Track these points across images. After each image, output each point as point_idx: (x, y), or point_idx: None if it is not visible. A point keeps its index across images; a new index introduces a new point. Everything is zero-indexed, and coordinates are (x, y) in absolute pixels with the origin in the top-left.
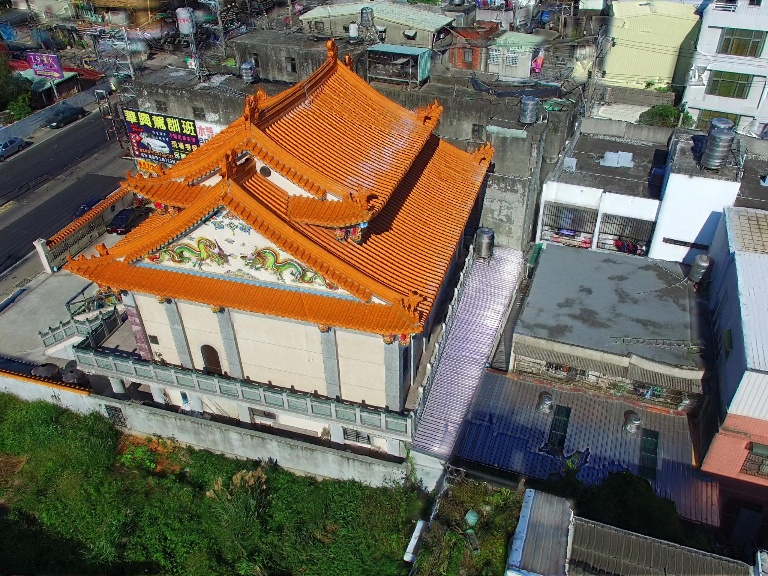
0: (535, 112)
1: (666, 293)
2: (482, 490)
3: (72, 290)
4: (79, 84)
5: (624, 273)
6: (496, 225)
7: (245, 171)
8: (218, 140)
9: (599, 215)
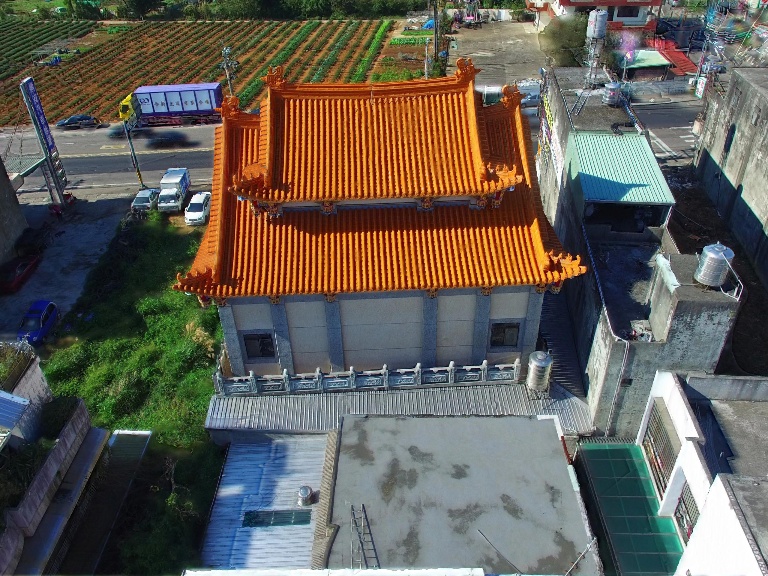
0: (714, 272)
1: (501, 569)
2: (8, 362)
3: None
4: (667, 75)
5: (529, 512)
6: (592, 374)
7: (252, 121)
8: None
9: (675, 465)
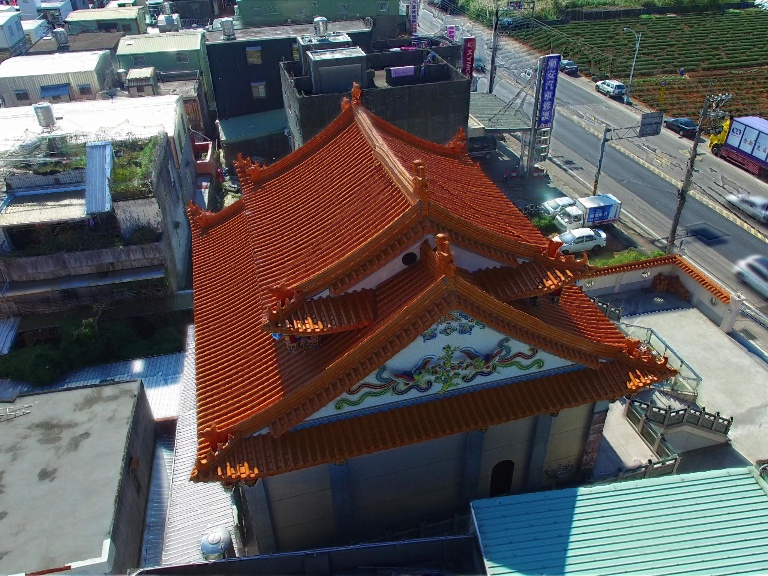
0: None
1: None
2: None
3: (729, 382)
4: None
5: None
6: None
7: None
8: (495, 199)
9: None
